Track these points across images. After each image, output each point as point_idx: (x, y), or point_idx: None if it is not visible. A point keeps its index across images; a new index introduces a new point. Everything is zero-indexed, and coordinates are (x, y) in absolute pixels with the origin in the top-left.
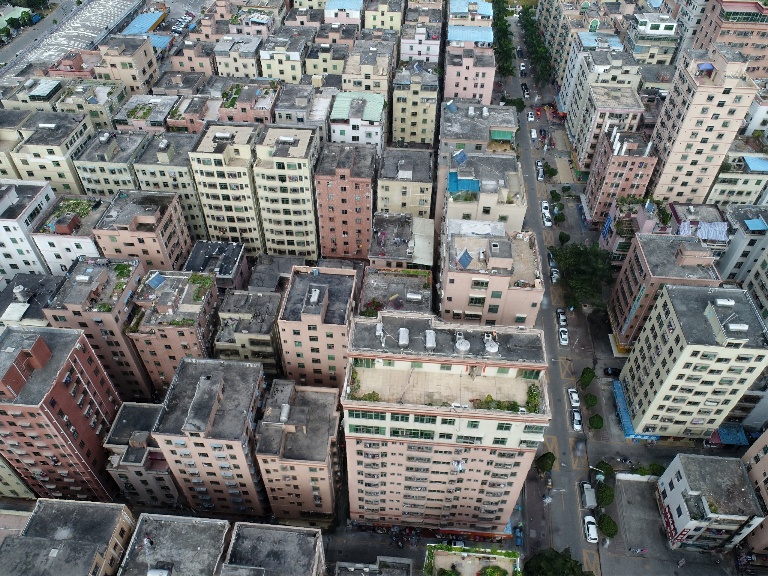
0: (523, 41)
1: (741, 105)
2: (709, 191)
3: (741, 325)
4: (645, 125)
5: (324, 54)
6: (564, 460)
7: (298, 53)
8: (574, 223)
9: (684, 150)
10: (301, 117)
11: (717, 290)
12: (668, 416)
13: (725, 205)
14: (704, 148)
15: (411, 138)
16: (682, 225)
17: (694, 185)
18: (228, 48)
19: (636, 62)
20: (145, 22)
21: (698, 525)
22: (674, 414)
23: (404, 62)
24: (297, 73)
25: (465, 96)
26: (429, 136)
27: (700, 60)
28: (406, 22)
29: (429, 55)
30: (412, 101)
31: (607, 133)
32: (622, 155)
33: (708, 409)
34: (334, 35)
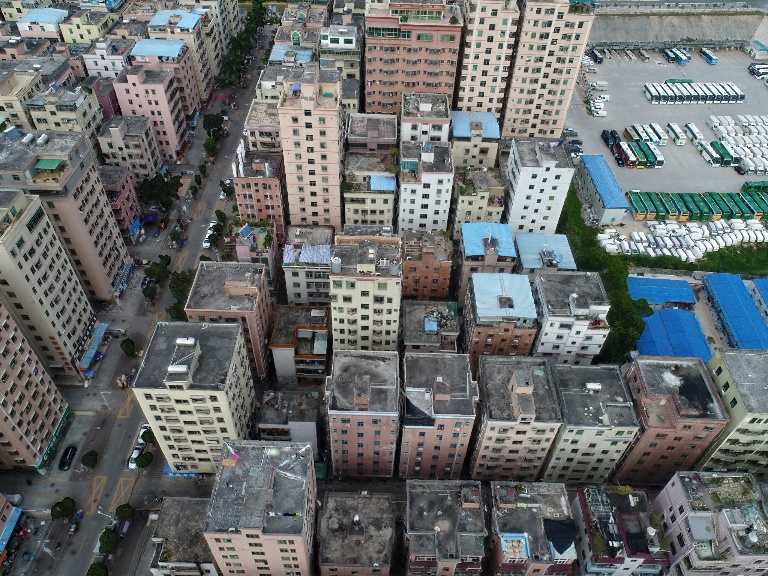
0: None
1: (329, 126)
2: (343, 210)
3: (179, 367)
4: None
5: None
6: (103, 502)
7: None
8: None
9: (297, 171)
10: None
11: (211, 325)
12: (186, 455)
13: (365, 224)
14: (315, 169)
15: None
16: (286, 249)
17: (324, 205)
18: None
19: None
20: None
21: (163, 572)
22: (190, 452)
23: (85, 78)
24: None
25: (143, 113)
26: None
27: (290, 81)
28: (105, 35)
29: (117, 70)
30: (53, 122)
31: None
32: (242, 177)
33: (216, 447)
34: (11, 51)
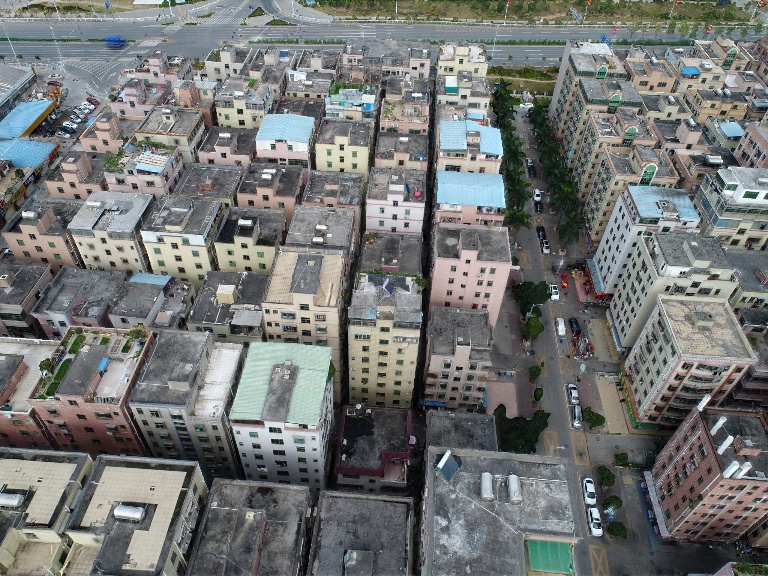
0: (535, 149)
1: None
2: None
3: None
4: (753, 378)
5: (243, 238)
6: None
7: (201, 236)
8: (637, 526)
9: None
10: (178, 414)
11: None
12: None
13: None
14: None
15: (379, 379)
16: None
17: None
18: (91, 224)
19: (729, 259)
20: (24, 118)
21: None
22: None
23: (371, 234)
24: (202, 260)
25: (463, 294)
26: (407, 378)
27: None
28: (376, 159)
29: (409, 220)
30: (379, 339)
31: (702, 413)
32: (738, 478)
33: None
34: (265, 191)
